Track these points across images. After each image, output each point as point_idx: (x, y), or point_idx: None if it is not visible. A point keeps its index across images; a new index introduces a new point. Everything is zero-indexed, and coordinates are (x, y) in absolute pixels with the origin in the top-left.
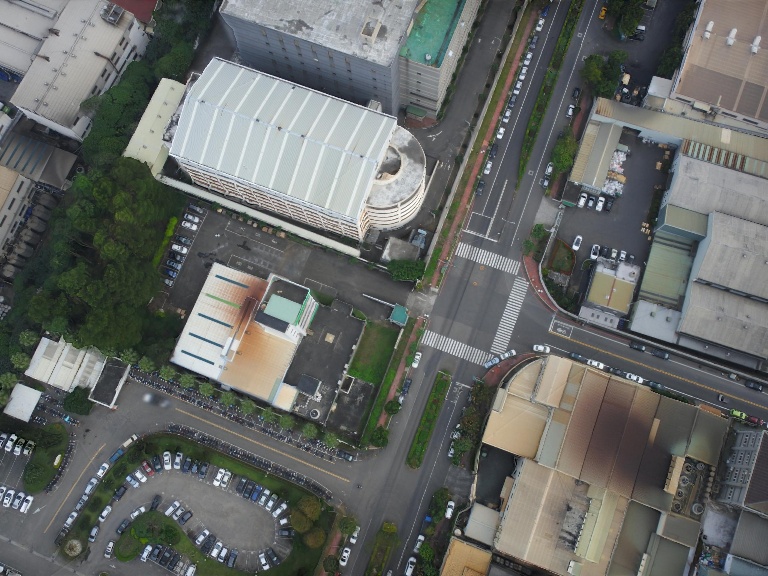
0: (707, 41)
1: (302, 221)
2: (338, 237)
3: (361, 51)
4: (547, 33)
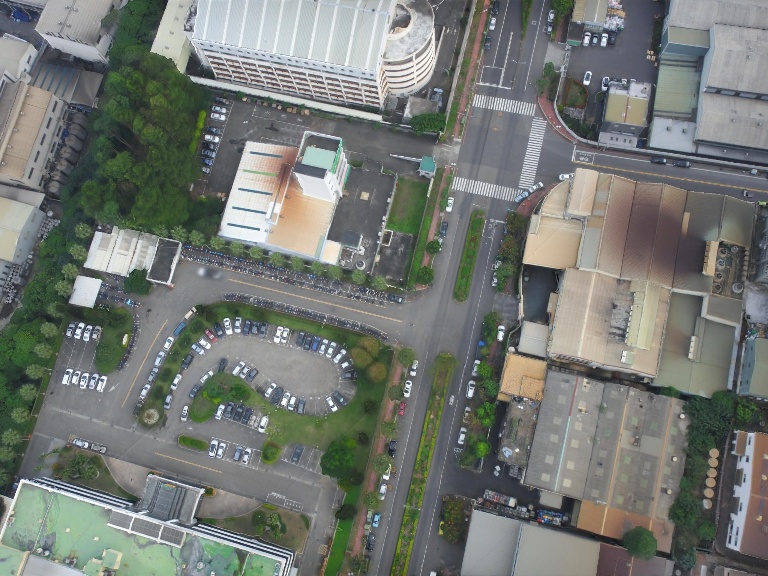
0: None
1: (323, 98)
2: (359, 107)
3: None
4: None
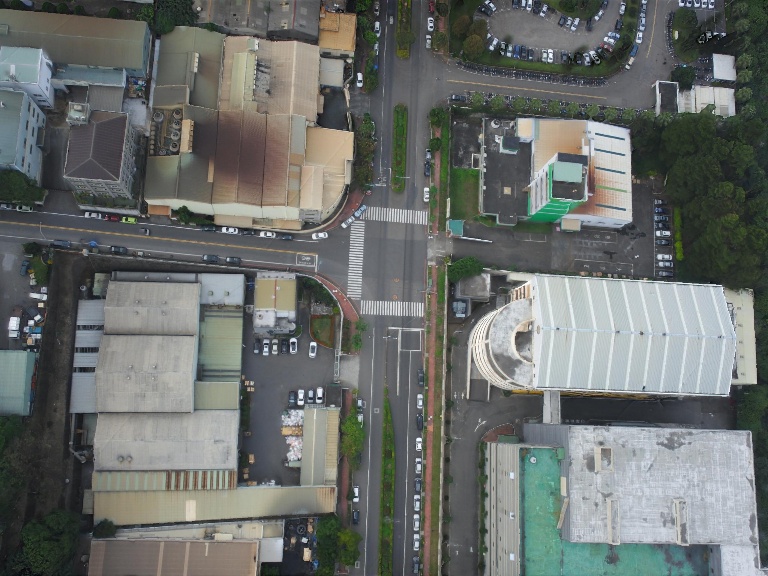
0: None
1: None
2: None
3: (602, 435)
4: None
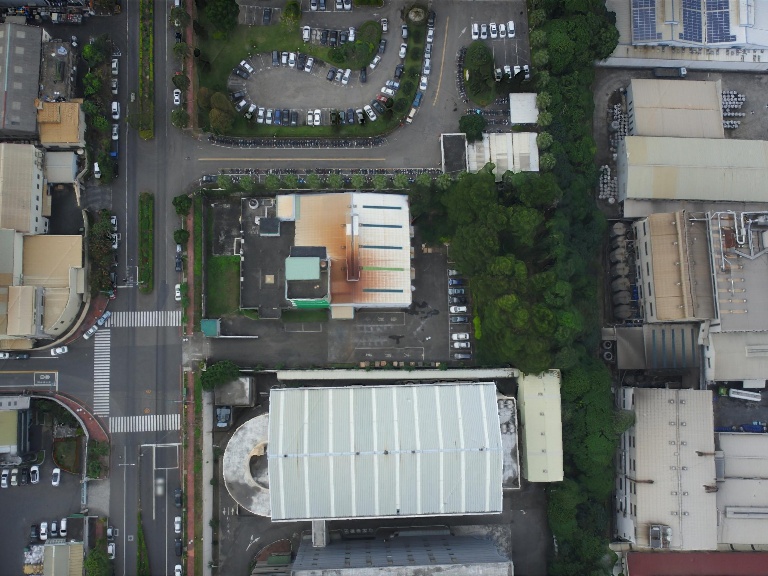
0: None
1: None
2: None
3: None
4: None
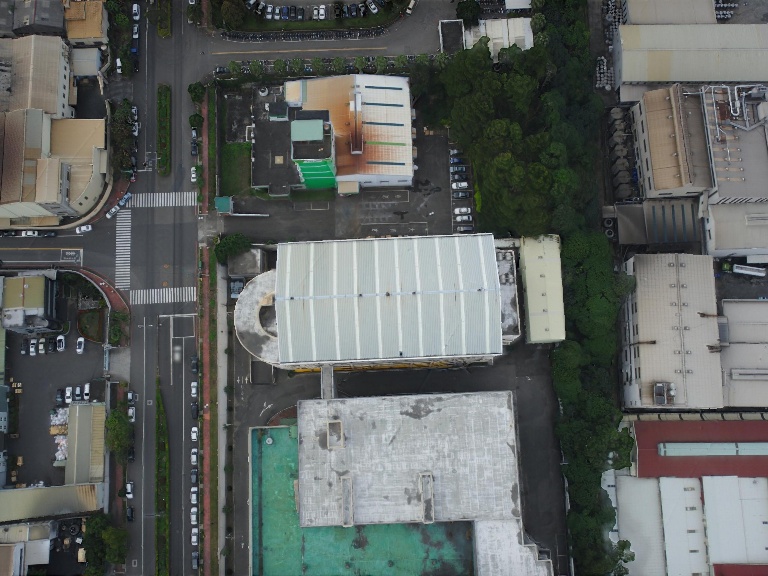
0: None
1: None
2: None
3: (337, 408)
4: None
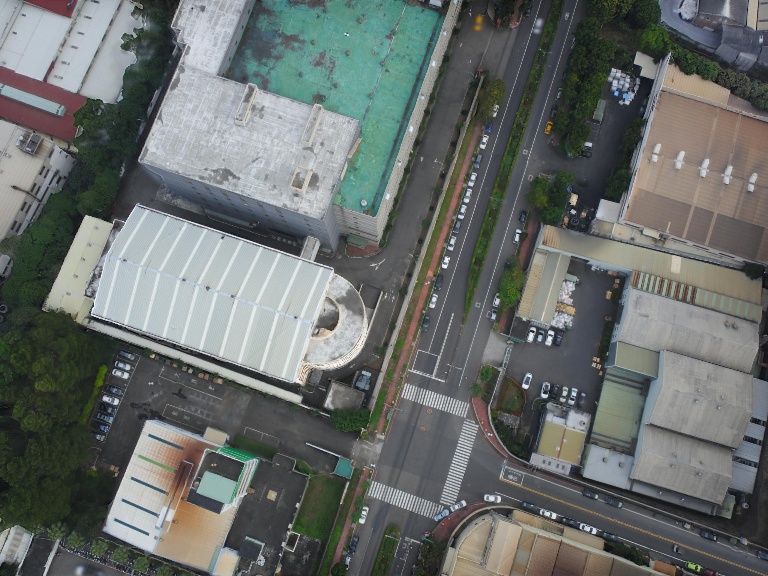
0: (655, 164)
1: None
2: (279, 381)
3: (292, 202)
4: (491, 151)
